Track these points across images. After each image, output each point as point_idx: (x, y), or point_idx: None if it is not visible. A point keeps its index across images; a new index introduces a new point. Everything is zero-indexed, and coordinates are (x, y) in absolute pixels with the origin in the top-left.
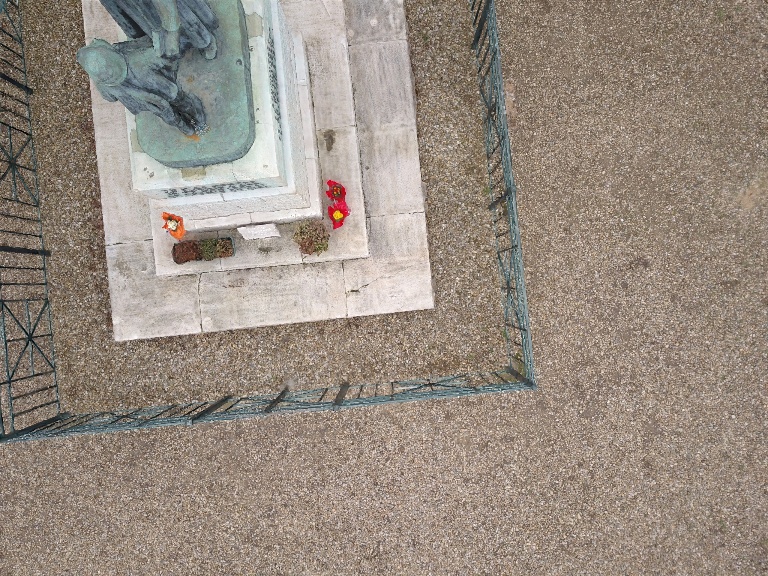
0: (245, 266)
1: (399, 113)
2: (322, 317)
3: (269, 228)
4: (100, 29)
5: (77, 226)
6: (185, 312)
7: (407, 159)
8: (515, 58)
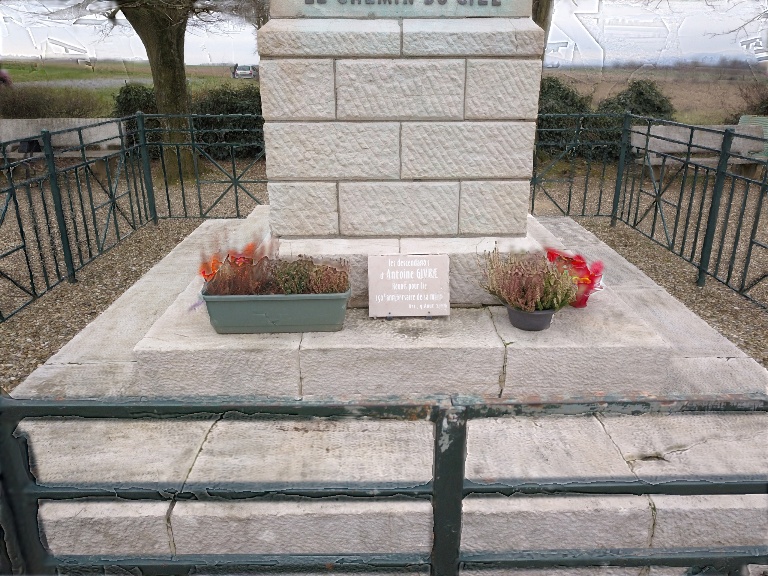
0: (359, 351)
1: (629, 280)
2: (570, 509)
3: (434, 270)
4: (209, 234)
5: (2, 381)
6: (145, 468)
7: (670, 310)
8: (767, 298)
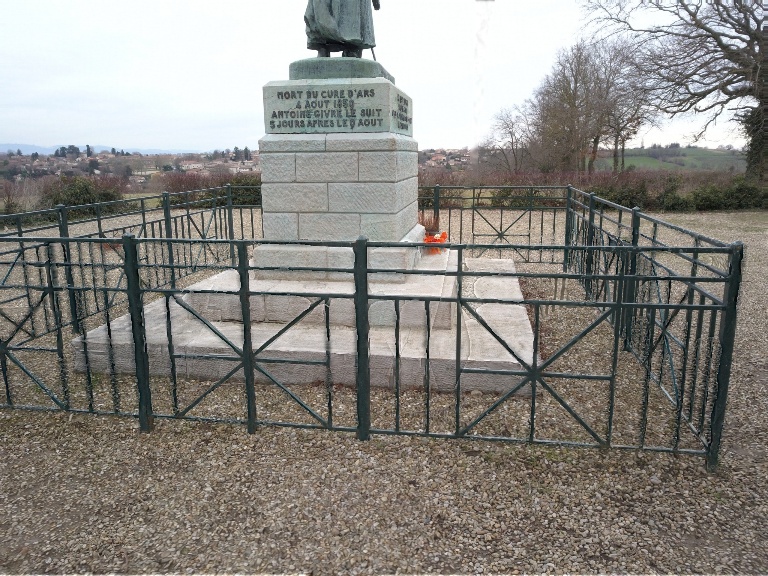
0: None
1: None
2: None
3: None
4: (511, 335)
5: None
6: None
7: None
8: None
